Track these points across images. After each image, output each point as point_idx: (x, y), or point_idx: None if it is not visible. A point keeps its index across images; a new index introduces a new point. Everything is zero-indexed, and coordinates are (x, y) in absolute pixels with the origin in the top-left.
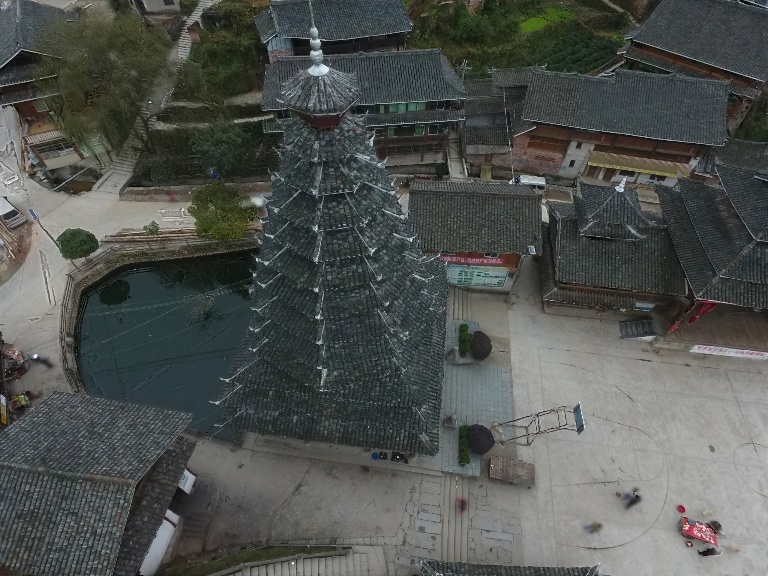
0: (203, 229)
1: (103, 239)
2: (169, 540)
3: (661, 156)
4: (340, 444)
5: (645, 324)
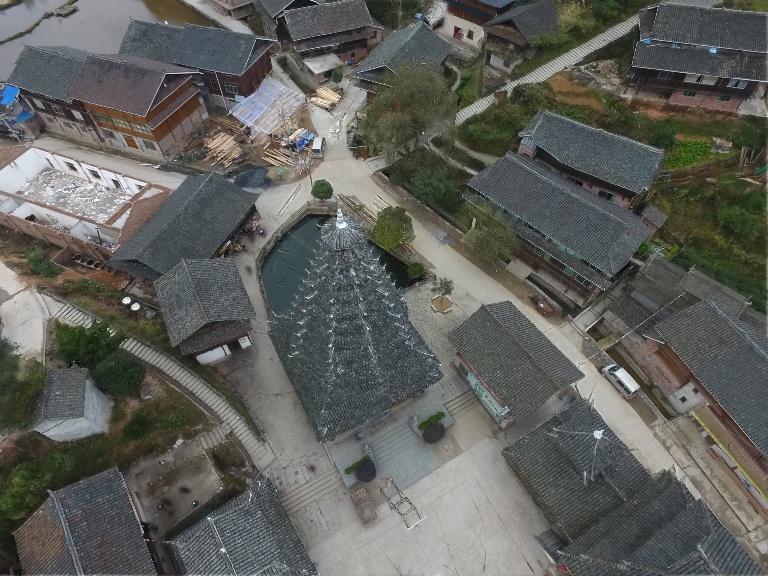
0: None
1: (339, 194)
2: (219, 358)
3: None
4: (296, 392)
5: None
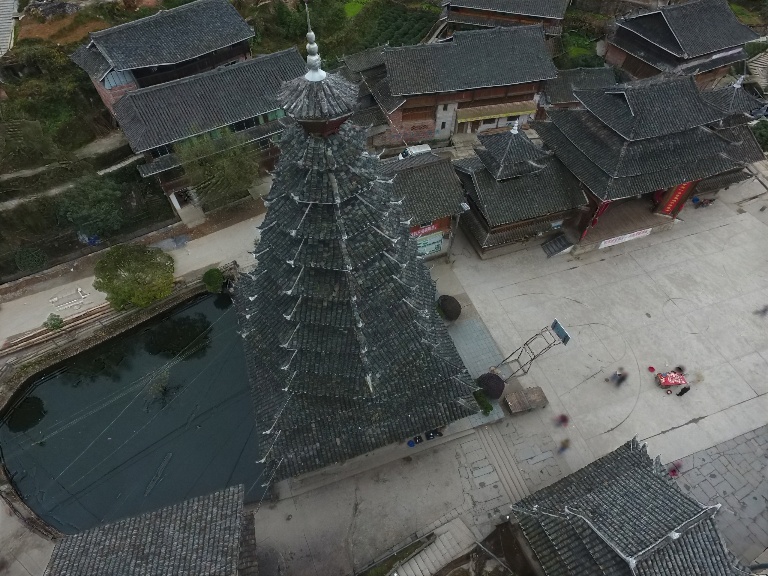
0: (120, 301)
1: None
2: None
3: (511, 99)
4: None
5: (561, 239)
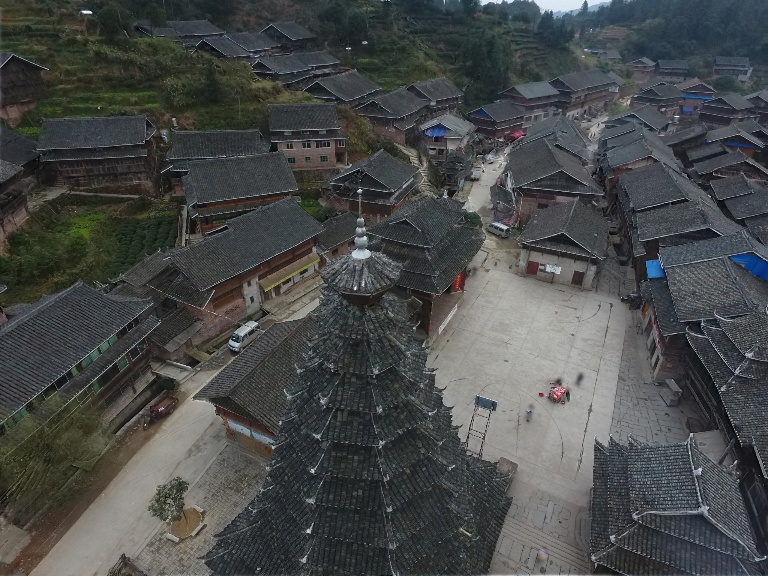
0: None
1: None
2: None
3: (297, 257)
4: None
5: None
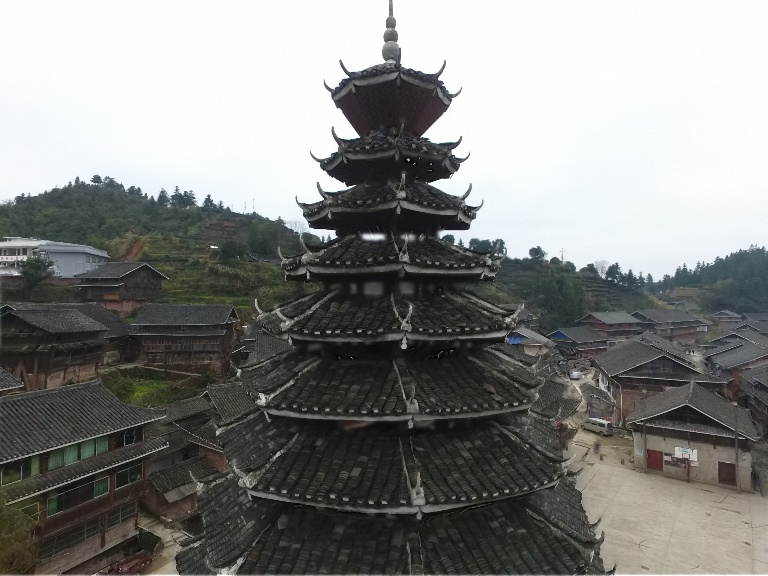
0: None
1: None
2: None
3: None
4: None
5: None
